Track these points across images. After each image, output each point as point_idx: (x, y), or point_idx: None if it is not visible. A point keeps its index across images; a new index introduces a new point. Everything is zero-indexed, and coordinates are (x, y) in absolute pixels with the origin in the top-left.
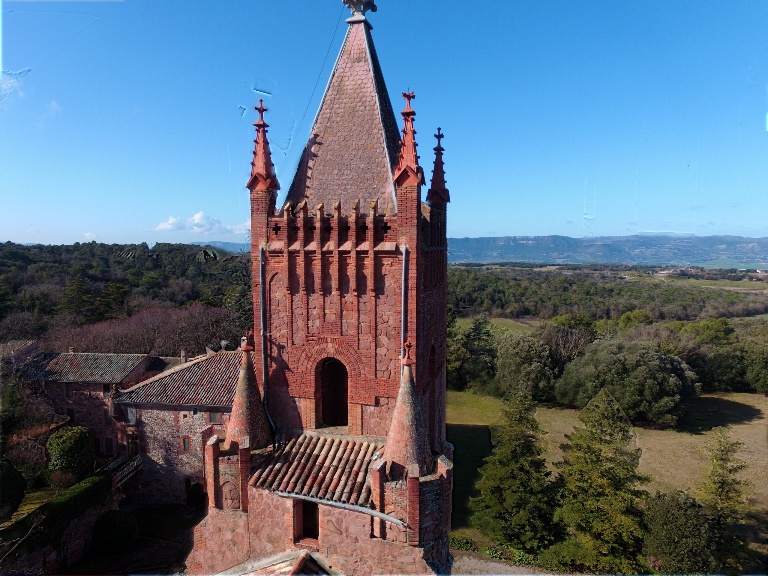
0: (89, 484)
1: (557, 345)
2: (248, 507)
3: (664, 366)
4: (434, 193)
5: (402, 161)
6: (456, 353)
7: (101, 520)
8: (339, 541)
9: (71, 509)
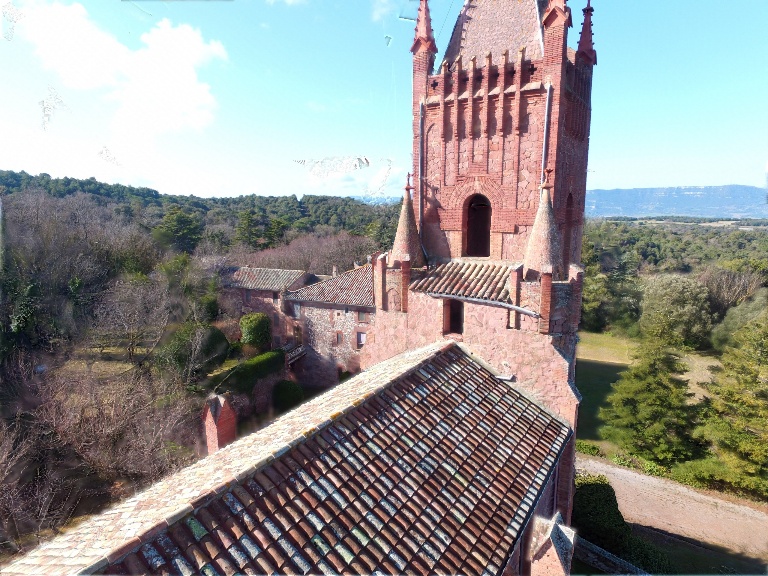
0: (269, 356)
1: (719, 288)
2: (407, 308)
3: None
4: (581, 54)
5: (551, 3)
6: (595, 292)
7: (278, 385)
8: (480, 332)
9: (258, 371)
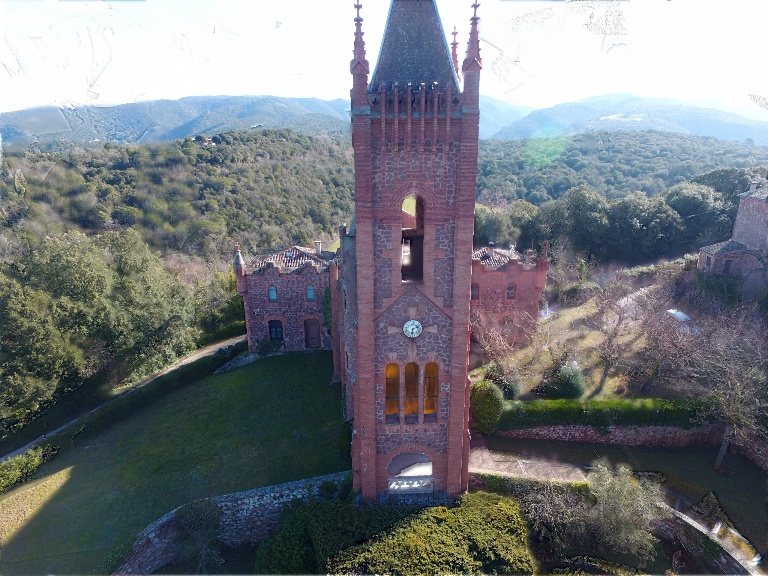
0: None
1: None
2: None
3: None
4: None
5: None
6: None
7: None
8: None
9: None
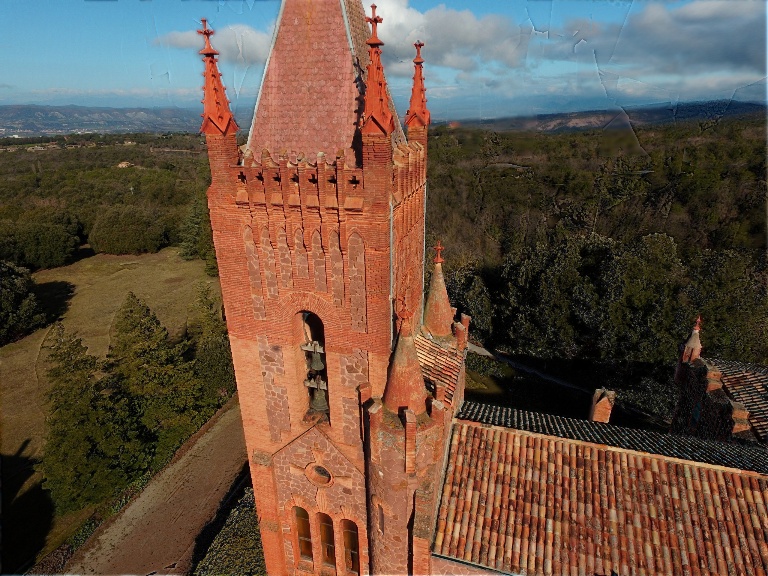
0: None
1: None
2: None
3: (1, 271)
4: None
5: None
6: None
7: None
8: None
9: None
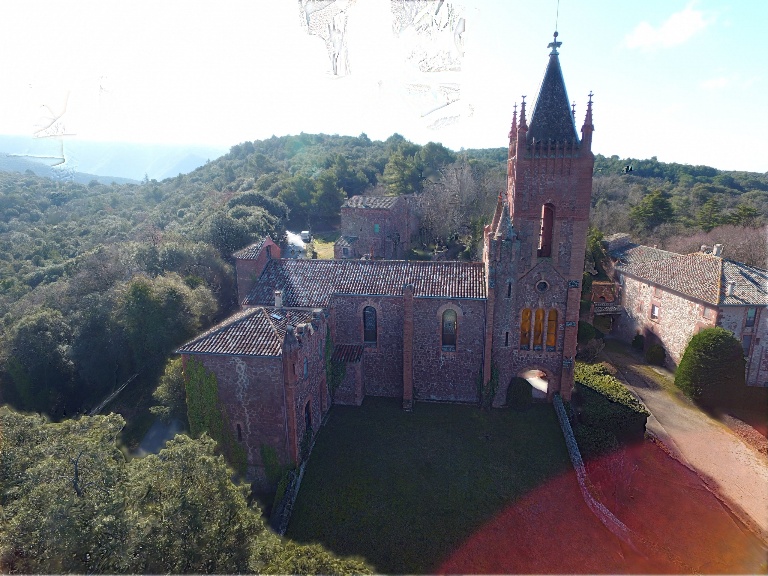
0: None
1: None
2: None
3: None
4: None
5: None
6: None
7: None
8: None
9: None
